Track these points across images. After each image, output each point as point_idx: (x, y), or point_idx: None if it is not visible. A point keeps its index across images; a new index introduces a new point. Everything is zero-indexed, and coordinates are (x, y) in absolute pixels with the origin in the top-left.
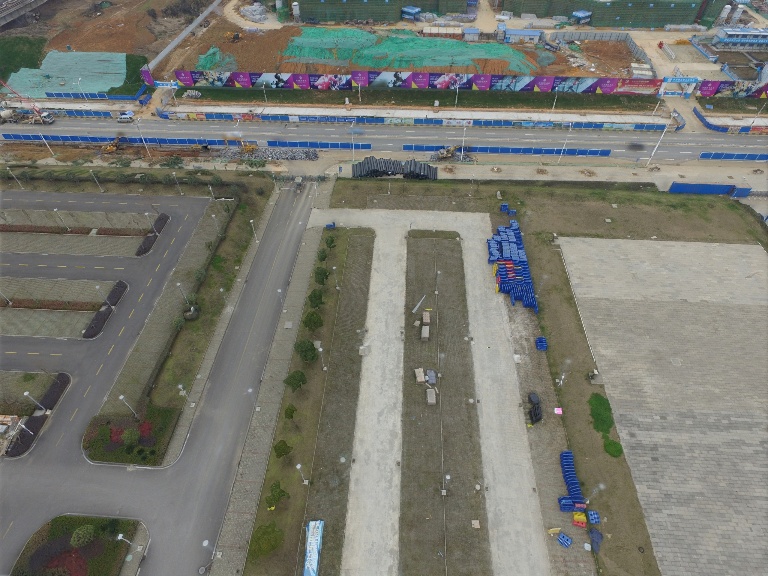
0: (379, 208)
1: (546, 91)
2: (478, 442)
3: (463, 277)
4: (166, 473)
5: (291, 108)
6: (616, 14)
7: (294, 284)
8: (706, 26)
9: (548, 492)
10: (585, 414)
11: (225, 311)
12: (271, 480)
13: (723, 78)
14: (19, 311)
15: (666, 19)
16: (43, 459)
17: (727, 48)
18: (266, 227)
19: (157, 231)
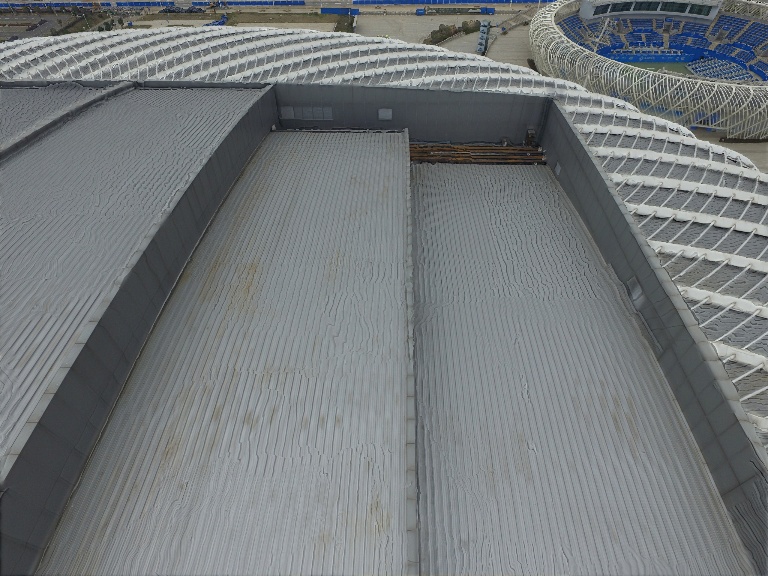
0: (160, 20)
1: None
2: None
3: None
4: None
5: None
6: None
7: None
8: None
9: None
10: None
11: None
12: None
13: None
14: None
15: None
16: None
17: None
18: None
19: (39, 24)
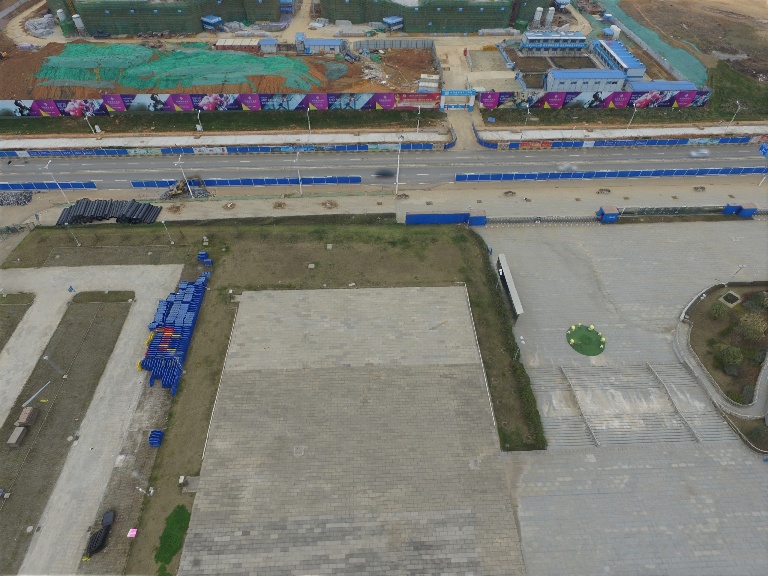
0: (57, 265)
1: (323, 109)
2: None
3: (110, 352)
4: None
5: (32, 140)
6: (427, 19)
7: None
8: (519, 30)
9: None
10: (155, 537)
11: None
12: None
13: (514, 87)
14: None
15: (479, 23)
16: None
17: (530, 53)
18: None
19: None
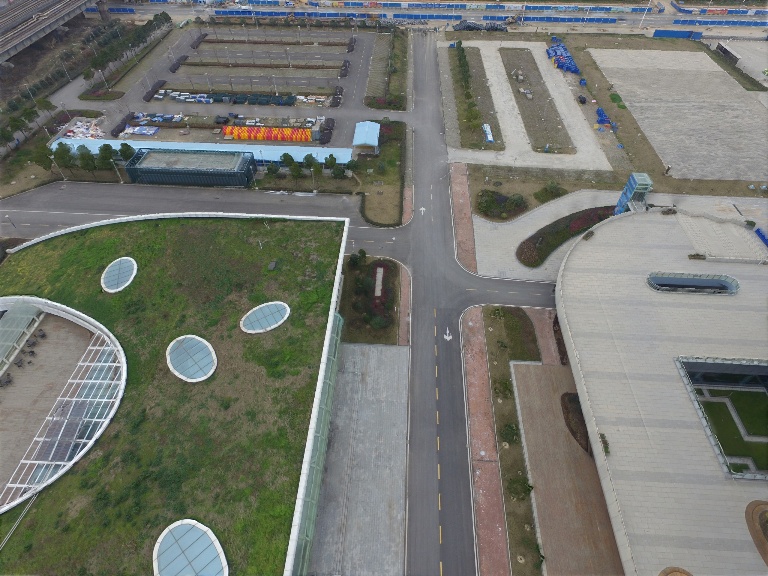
0: (478, 40)
1: None
2: (556, 109)
3: (535, 63)
4: (409, 113)
5: (398, 2)
6: None
7: (441, 64)
8: None
9: (592, 120)
10: (608, 99)
11: (409, 72)
12: (461, 114)
13: None
14: (297, 70)
15: None
16: (348, 108)
17: None
18: (413, 47)
19: (354, 43)
